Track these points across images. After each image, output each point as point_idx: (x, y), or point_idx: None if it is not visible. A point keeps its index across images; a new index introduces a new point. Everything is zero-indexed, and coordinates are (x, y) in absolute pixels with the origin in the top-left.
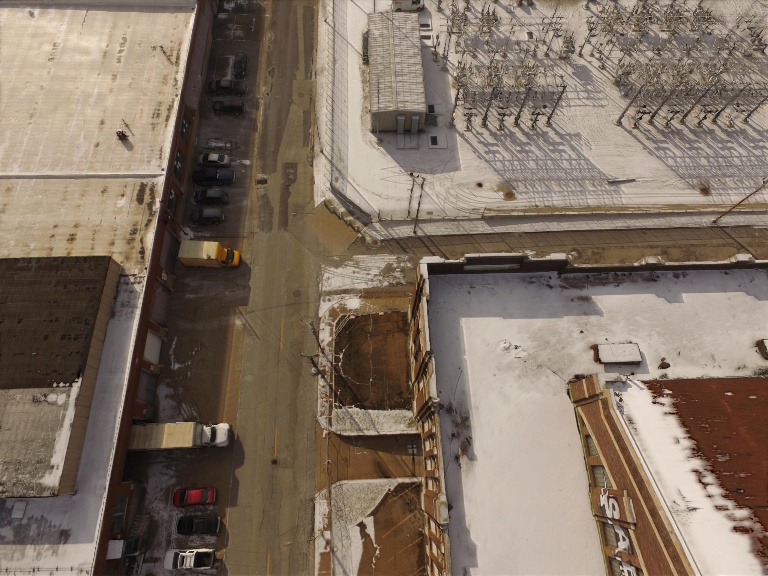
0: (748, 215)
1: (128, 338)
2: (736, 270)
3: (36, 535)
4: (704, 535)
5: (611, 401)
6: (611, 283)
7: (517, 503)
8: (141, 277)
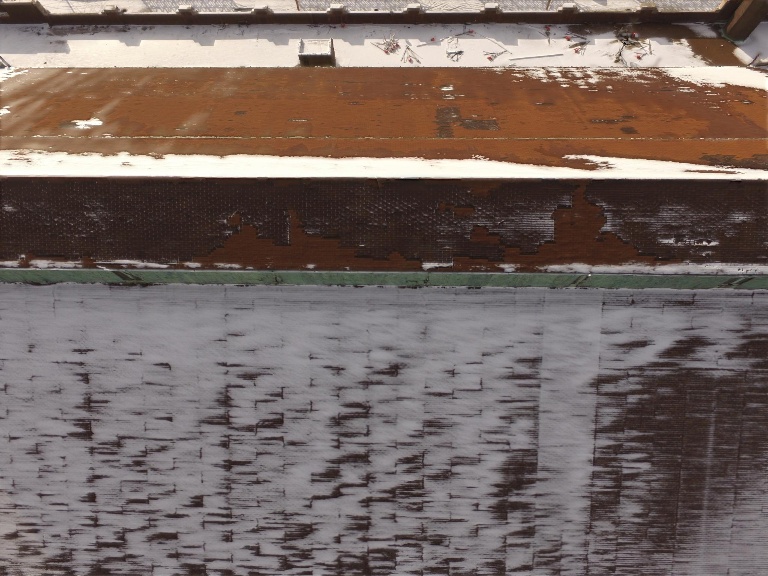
0: None
1: None
2: (196, 25)
3: None
4: None
5: None
6: (88, 32)
7: None
8: None
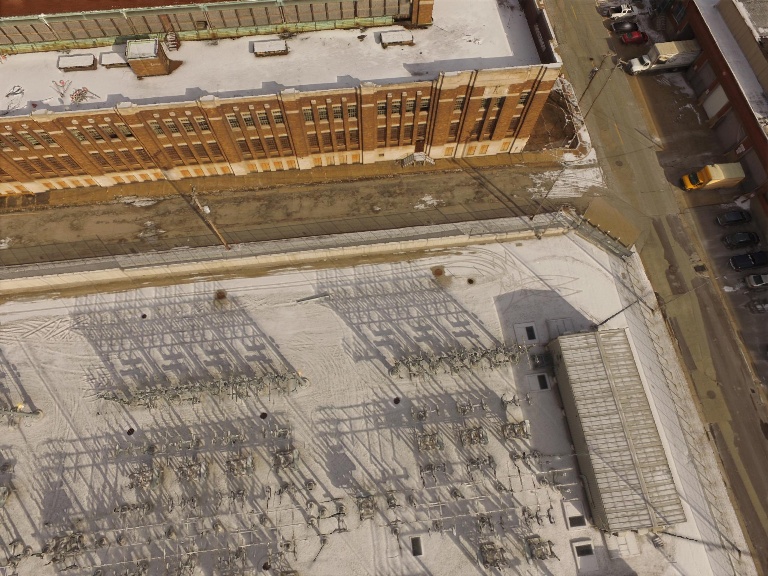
0: (189, 260)
1: (741, 81)
2: None
3: None
4: None
5: None
6: None
7: None
8: (761, 123)
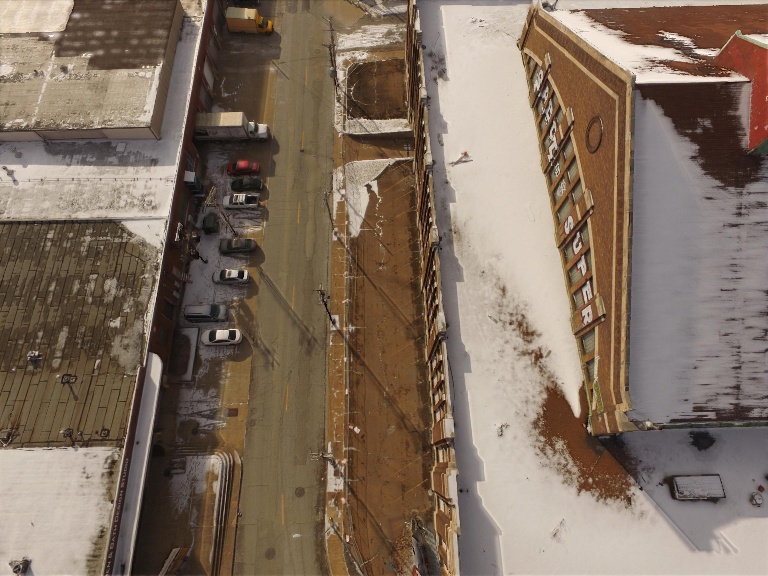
0: None
1: (192, 52)
2: None
3: (134, 161)
4: (587, 35)
5: (539, 6)
6: None
7: (477, 102)
8: (200, 18)
